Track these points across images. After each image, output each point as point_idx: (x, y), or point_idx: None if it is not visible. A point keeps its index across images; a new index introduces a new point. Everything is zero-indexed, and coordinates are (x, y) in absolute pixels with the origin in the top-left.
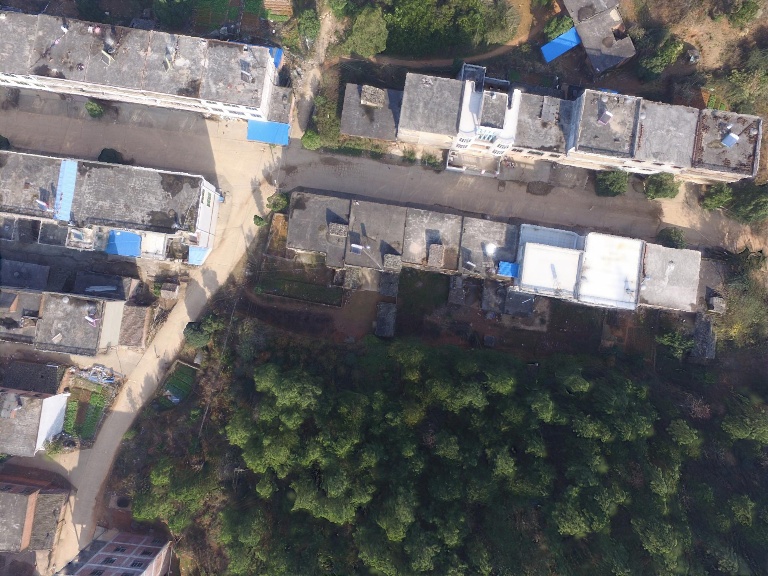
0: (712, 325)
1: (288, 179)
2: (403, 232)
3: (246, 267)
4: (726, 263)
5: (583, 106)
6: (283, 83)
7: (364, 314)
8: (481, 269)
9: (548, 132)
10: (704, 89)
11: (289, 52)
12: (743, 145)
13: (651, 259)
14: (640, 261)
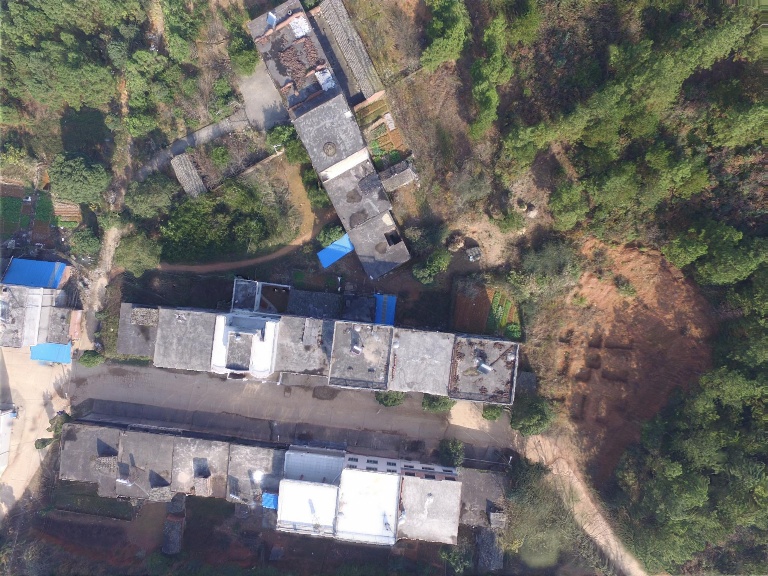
0: (497, 536)
1: (78, 391)
2: (171, 461)
3: (40, 482)
4: (506, 475)
5: (333, 339)
6: (70, 295)
7: (155, 526)
8: (249, 497)
9: (311, 355)
10: (488, 286)
11: (76, 262)
12: (500, 372)
13: (409, 492)
14: (398, 494)
